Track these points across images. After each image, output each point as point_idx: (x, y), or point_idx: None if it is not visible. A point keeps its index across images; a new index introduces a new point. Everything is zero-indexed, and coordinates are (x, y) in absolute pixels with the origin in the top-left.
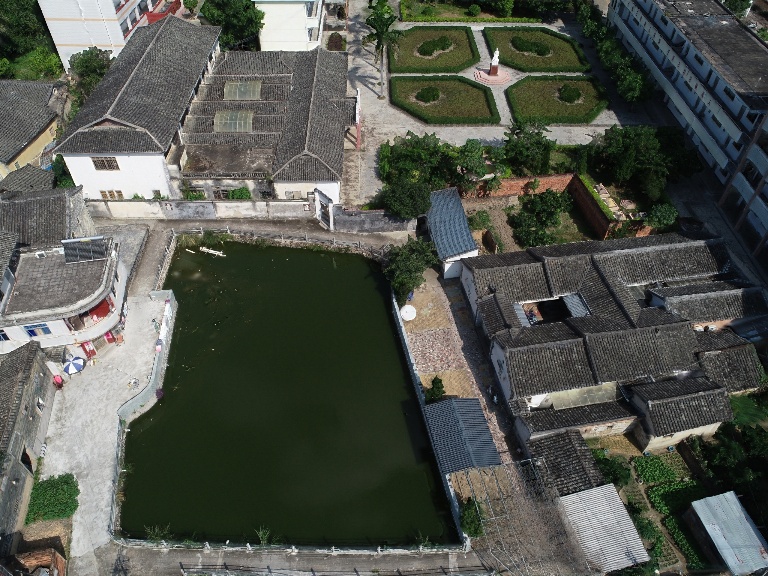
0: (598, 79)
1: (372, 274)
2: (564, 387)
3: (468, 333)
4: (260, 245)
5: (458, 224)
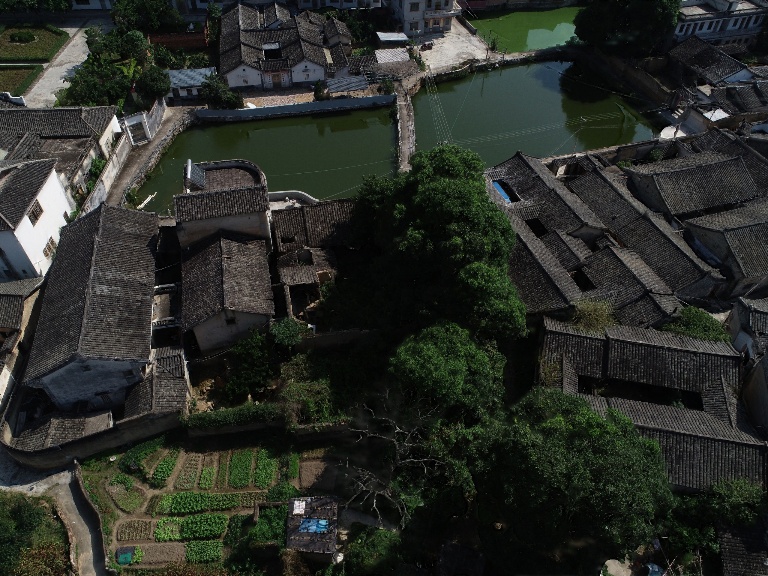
0: (11, 24)
1: (202, 128)
2: (324, 54)
3: (269, 94)
4: (150, 176)
5: (186, 73)
